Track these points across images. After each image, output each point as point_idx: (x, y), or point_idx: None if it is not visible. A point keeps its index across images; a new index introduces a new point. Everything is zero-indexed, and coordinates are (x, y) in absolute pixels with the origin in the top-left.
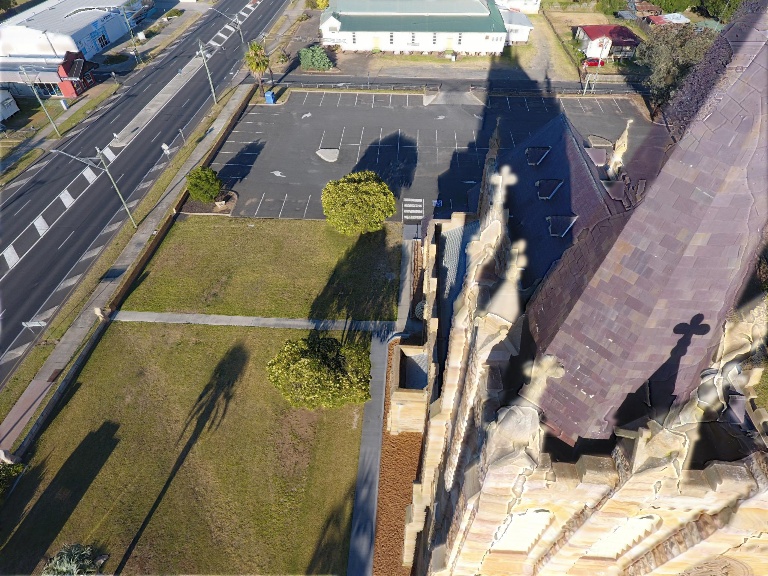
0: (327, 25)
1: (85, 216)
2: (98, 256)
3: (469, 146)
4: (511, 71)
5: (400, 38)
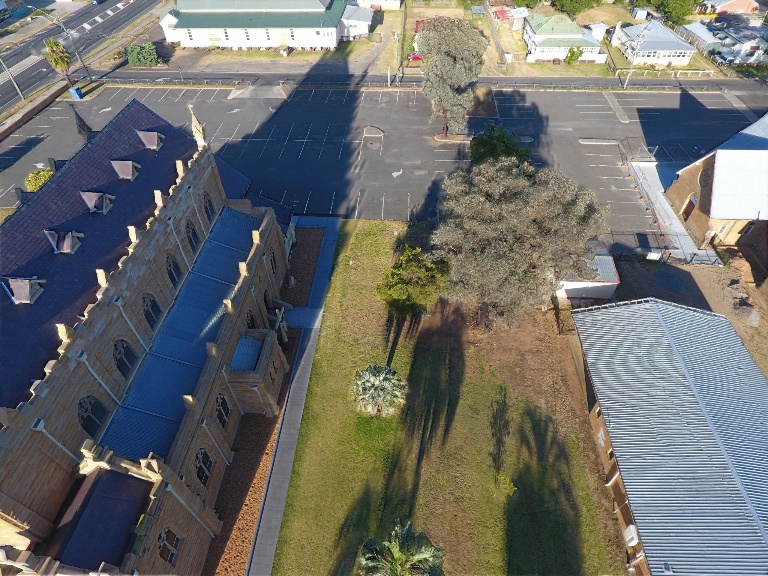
0: (166, 22)
1: None
2: None
3: (243, 138)
4: (335, 65)
5: (235, 34)
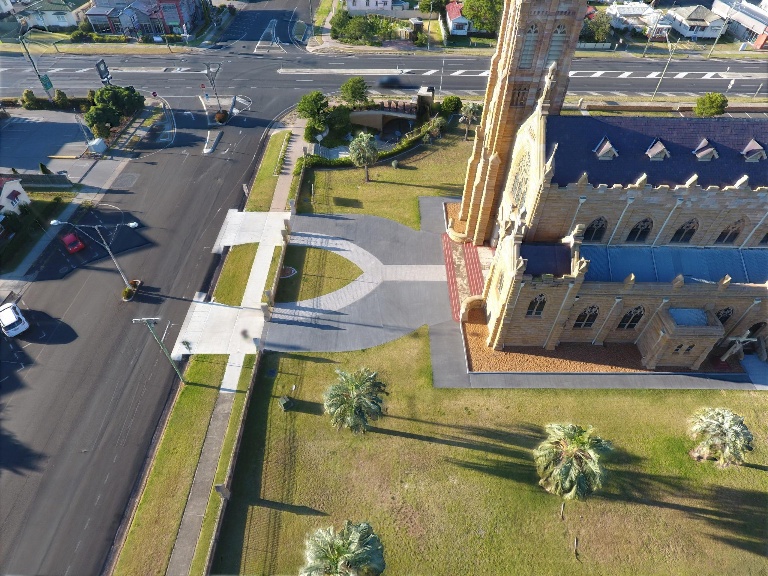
0: None
1: (645, 84)
2: (619, 96)
3: None
4: None
5: None
